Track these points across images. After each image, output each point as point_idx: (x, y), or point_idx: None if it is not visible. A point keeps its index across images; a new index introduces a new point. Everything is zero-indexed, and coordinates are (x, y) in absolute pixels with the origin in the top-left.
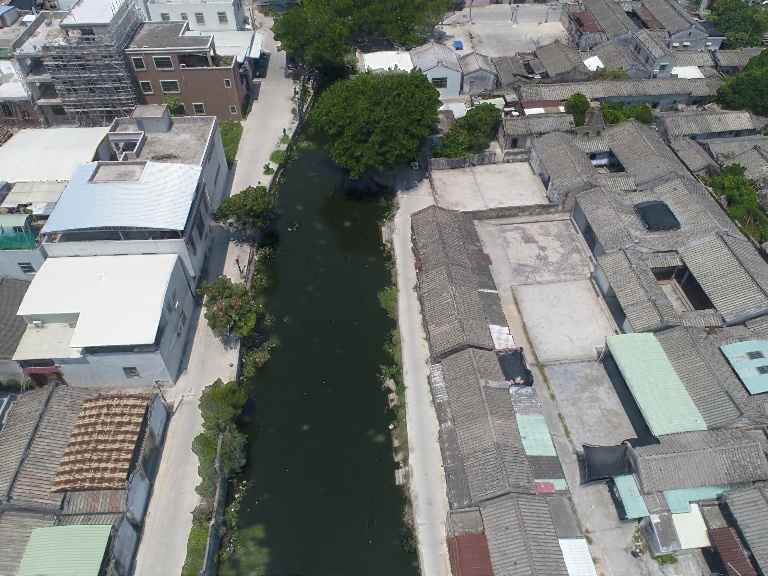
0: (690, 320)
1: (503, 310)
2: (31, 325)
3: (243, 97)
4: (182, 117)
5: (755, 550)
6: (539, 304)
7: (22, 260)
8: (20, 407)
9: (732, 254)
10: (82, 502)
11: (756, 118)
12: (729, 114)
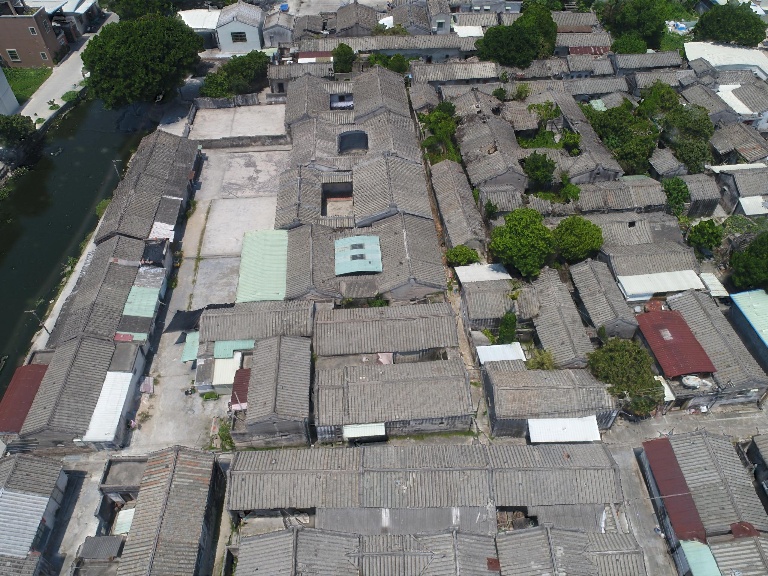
0: (326, 221)
1: (193, 217)
2: None
3: (59, 46)
4: None
5: (251, 380)
6: (227, 213)
7: None
8: None
9: (386, 170)
10: None
11: (501, 68)
12: (476, 64)
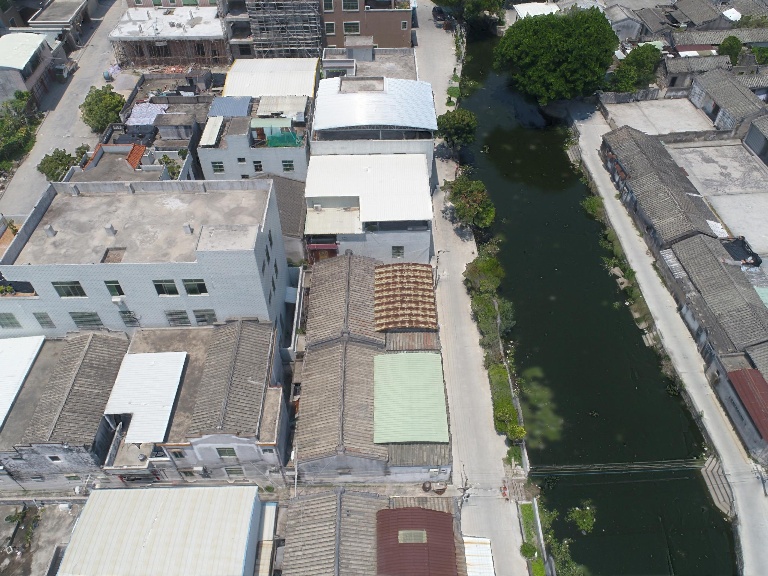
0: None
1: None
2: (310, 209)
3: None
4: (384, 48)
5: None
6: (734, 210)
7: (287, 158)
8: (320, 272)
9: None
10: (400, 341)
11: None
12: None
